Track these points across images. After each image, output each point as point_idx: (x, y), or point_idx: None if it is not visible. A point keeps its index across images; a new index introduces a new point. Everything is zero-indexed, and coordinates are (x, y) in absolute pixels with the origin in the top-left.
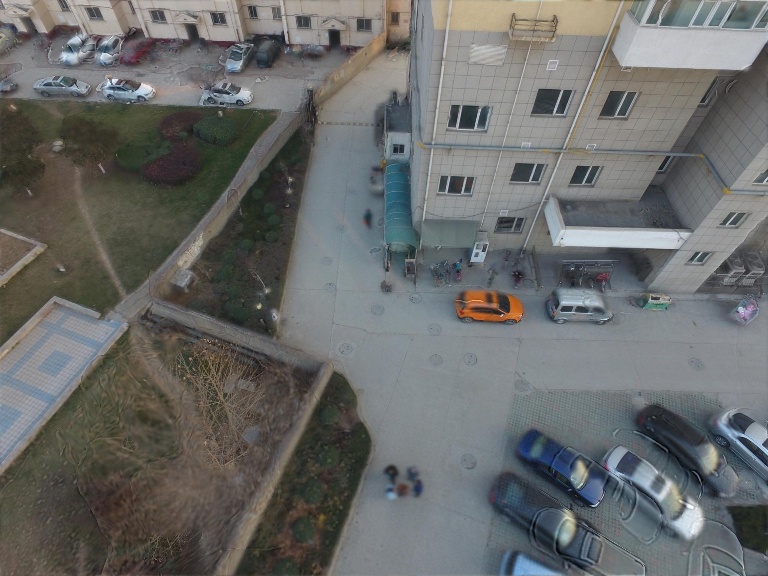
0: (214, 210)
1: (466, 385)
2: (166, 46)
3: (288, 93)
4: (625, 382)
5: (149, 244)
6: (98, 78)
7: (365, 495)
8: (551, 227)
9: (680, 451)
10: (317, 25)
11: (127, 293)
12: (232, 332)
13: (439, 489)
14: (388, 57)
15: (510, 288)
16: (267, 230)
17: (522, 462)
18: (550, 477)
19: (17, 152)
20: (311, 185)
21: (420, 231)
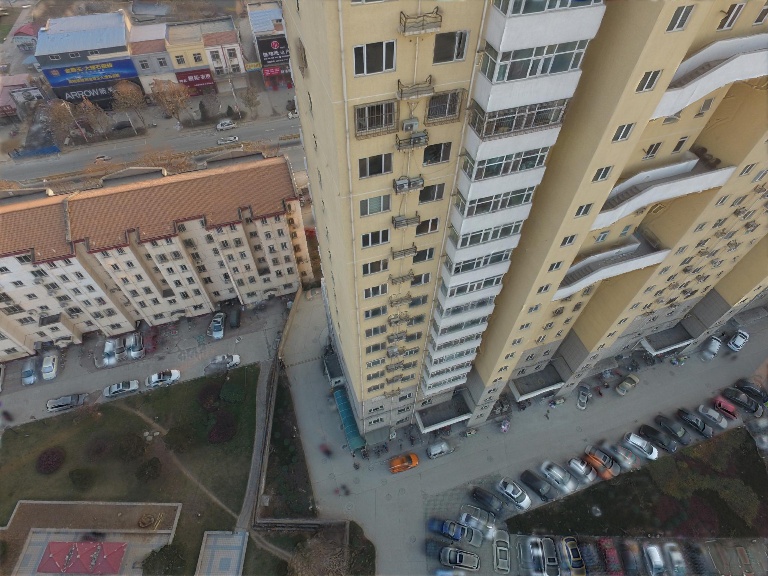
0: (256, 449)
1: (404, 505)
2: (165, 328)
3: (258, 345)
4: (464, 479)
5: (233, 483)
6: (136, 370)
7: (379, 569)
8: (419, 425)
9: (486, 505)
10: (260, 294)
11: (238, 515)
12: (302, 521)
13: (405, 555)
14: (307, 298)
15: (410, 447)
16: (291, 456)
17: (432, 531)
18: (443, 534)
19: (139, 456)
20: (299, 415)
21: (365, 439)
